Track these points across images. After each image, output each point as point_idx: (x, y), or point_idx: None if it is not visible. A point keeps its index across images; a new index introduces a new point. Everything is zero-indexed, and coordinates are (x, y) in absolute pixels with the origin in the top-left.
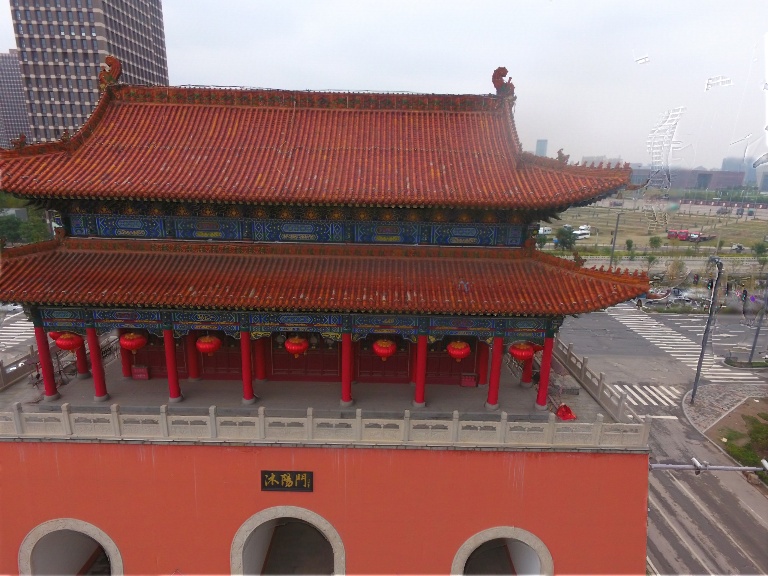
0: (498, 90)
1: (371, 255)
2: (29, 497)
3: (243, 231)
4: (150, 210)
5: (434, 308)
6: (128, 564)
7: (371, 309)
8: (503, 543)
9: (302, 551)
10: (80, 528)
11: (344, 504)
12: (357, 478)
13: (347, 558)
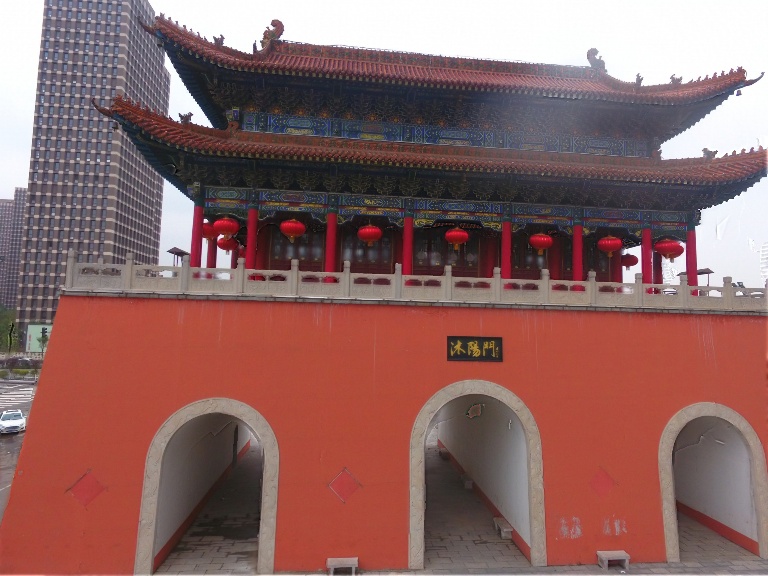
0: (592, 64)
1: (521, 158)
2: (177, 371)
3: (404, 135)
4: (319, 113)
5: (606, 172)
6: (284, 462)
7: (550, 171)
8: (706, 425)
9: (442, 511)
10: (234, 410)
11: (536, 376)
12: (548, 345)
13: (543, 447)
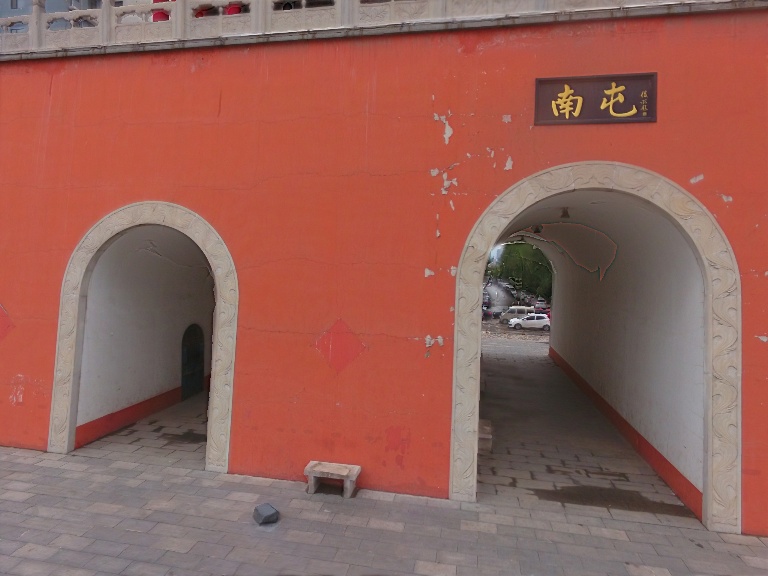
0: None
1: None
2: None
3: None
4: None
5: None
6: None
7: None
8: None
9: None
10: None
11: None
12: None
13: None
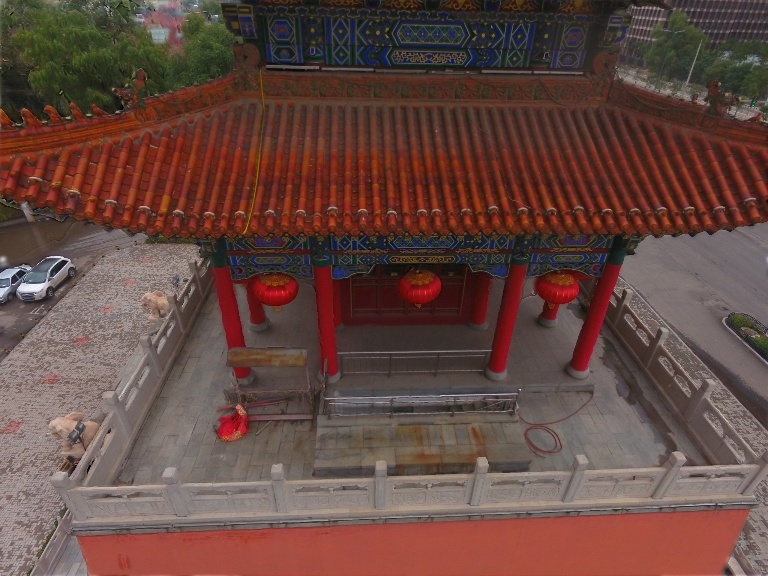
0: None
1: None
2: None
3: None
4: None
5: None
6: None
7: None
8: None
9: None
10: None
11: None
12: None
13: None
